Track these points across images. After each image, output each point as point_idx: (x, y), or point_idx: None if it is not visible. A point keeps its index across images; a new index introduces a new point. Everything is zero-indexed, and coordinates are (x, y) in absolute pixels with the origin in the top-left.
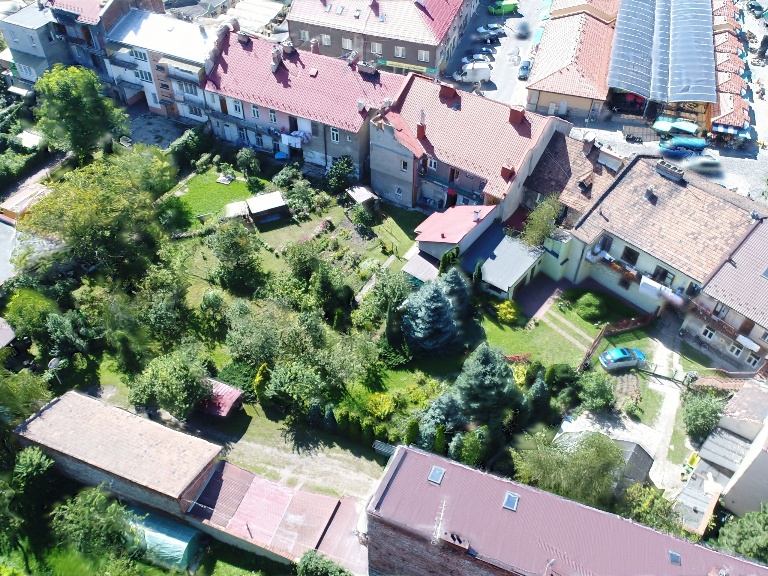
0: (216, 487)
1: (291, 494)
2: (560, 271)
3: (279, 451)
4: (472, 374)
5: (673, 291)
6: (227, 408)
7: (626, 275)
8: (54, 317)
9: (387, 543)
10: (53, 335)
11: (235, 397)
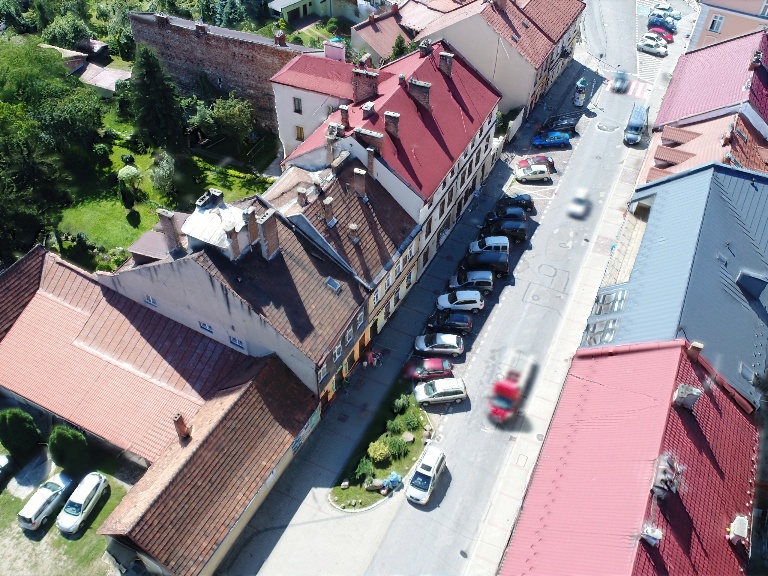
0: (82, 71)
1: (122, 74)
2: (322, 9)
3: (125, 71)
4: (225, 15)
5: (372, 5)
6: (98, 48)
7: (351, 1)
8: (4, 1)
9: (141, 38)
10: (3, 9)
11: (104, 44)
